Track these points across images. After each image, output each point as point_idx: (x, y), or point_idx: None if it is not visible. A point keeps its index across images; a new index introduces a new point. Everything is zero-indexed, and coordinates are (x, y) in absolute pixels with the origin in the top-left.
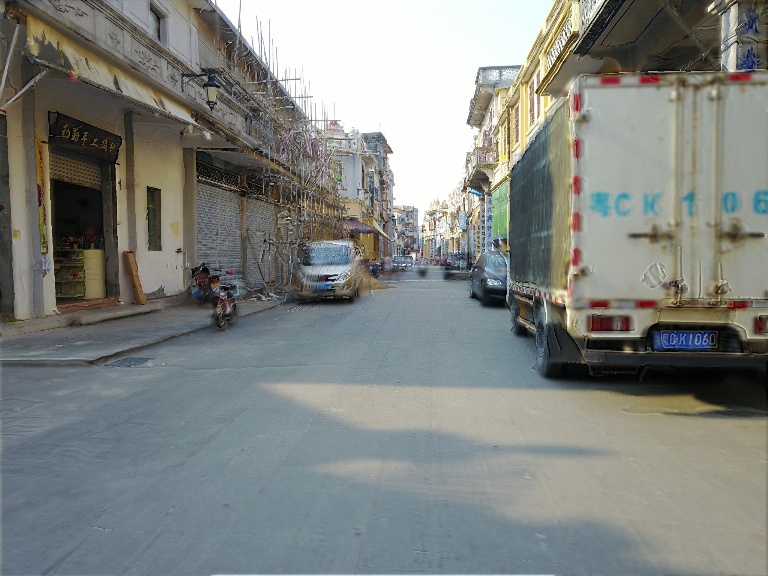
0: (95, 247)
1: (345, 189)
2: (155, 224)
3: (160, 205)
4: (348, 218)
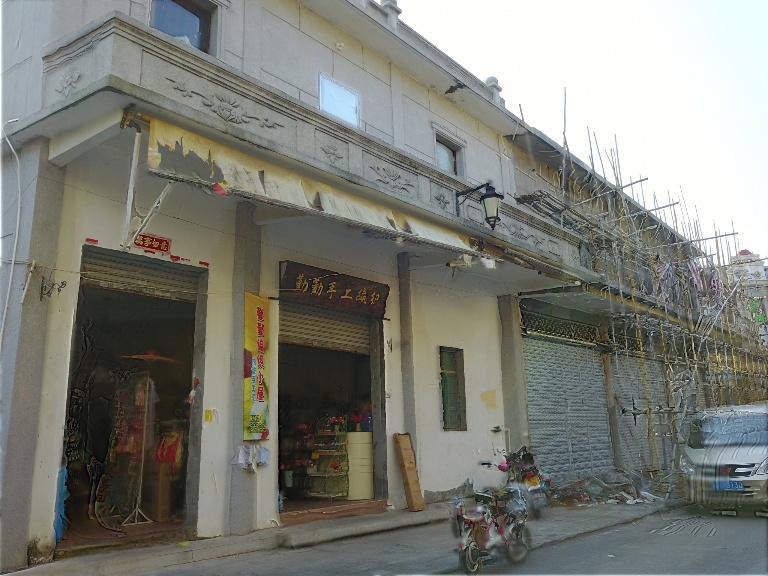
0: (362, 429)
1: None
2: (458, 395)
3: (463, 369)
4: None
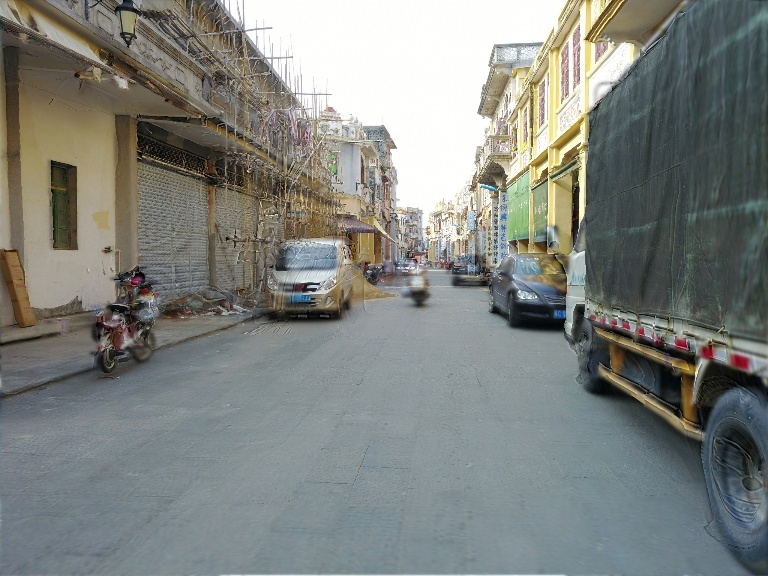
0: None
1: (341, 182)
2: (69, 213)
3: (76, 188)
4: (345, 216)
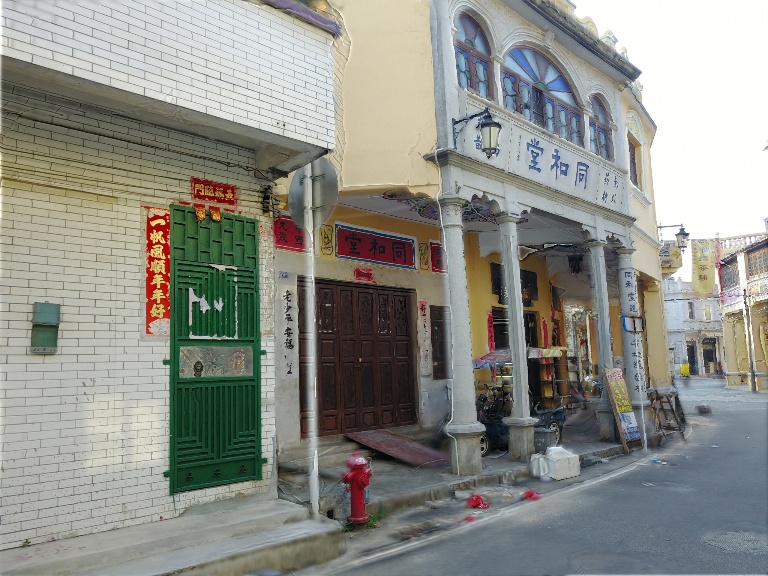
0: (712, 362)
1: None
2: None
3: None
4: None
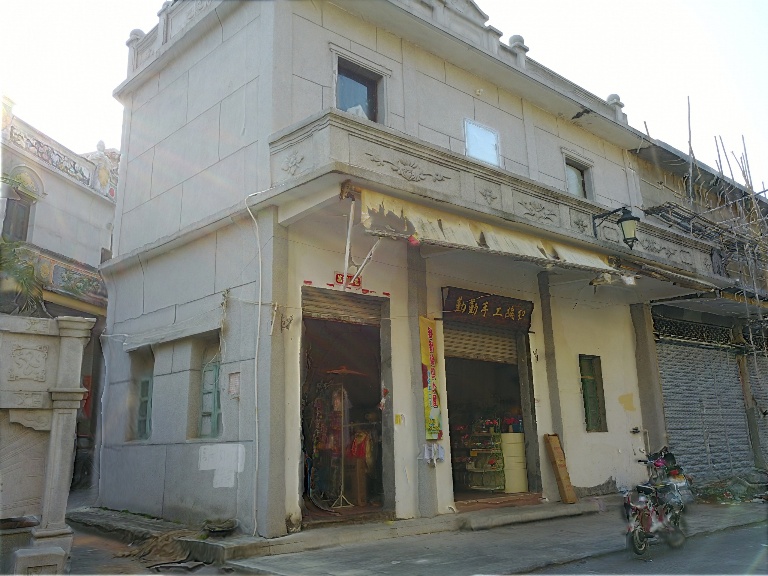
0: (514, 430)
1: None
2: (597, 399)
3: (601, 375)
4: None
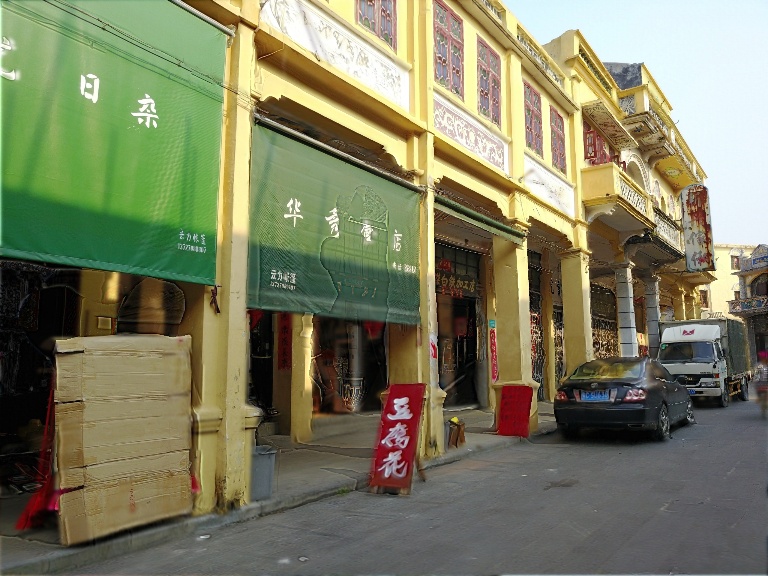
0: None
1: None
2: None
3: None
4: None
